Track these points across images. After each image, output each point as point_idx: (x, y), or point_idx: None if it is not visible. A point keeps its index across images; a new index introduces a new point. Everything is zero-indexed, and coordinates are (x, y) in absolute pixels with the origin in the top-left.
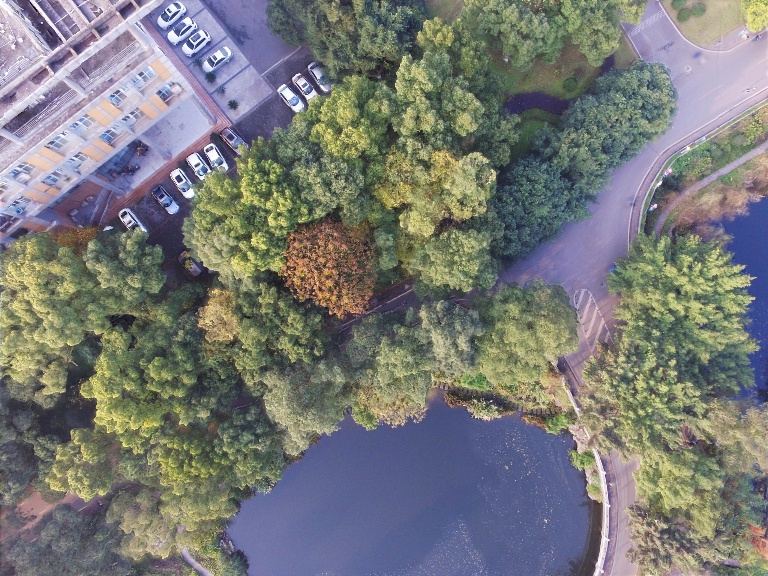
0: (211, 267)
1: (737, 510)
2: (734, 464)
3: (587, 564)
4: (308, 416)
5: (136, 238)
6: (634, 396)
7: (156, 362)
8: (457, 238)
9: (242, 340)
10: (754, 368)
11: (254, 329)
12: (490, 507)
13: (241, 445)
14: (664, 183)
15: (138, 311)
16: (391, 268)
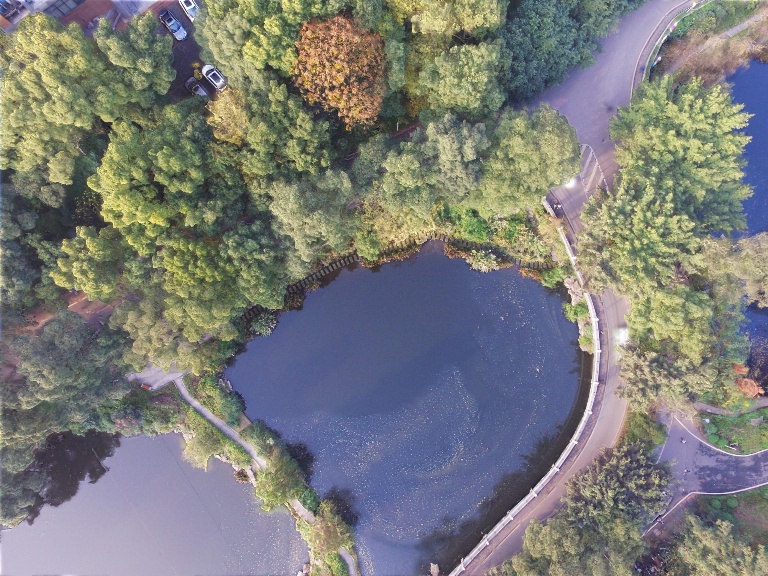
0: (222, 60)
1: (722, 351)
2: (723, 295)
3: (576, 412)
4: (314, 216)
5: (148, 21)
6: (631, 229)
7: (165, 149)
8: (467, 52)
9: (250, 141)
10: (746, 213)
11: (263, 123)
12: (485, 355)
13: (246, 251)
14: (669, 41)
15: (145, 119)
16: (398, 101)
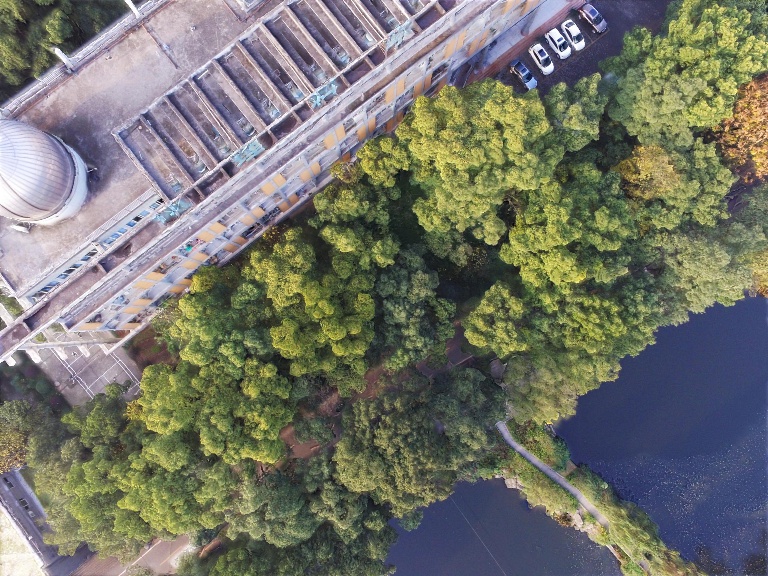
0: (656, 119)
1: None
2: None
3: None
4: (739, 271)
5: None
6: None
7: None
8: None
9: (667, 197)
10: None
11: (697, 181)
12: None
13: None
14: None
15: None
16: None
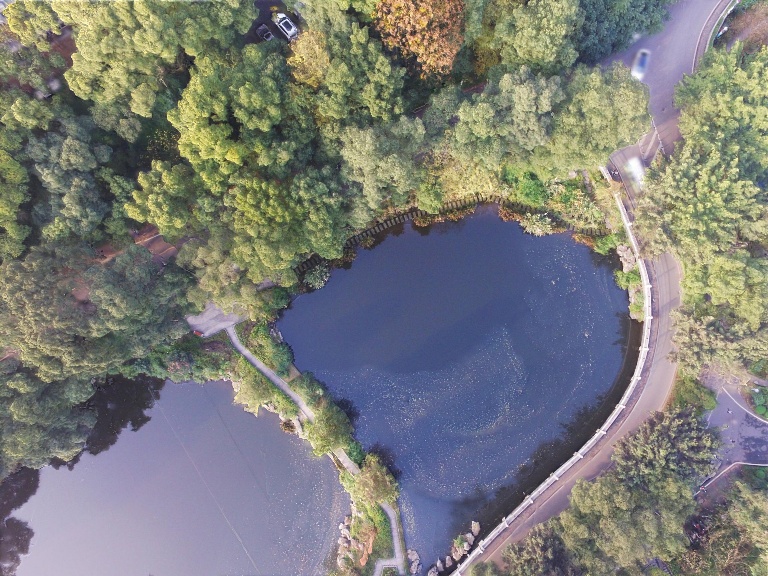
0: None
1: None
2: None
3: (622, 379)
4: (389, 159)
5: None
6: (694, 192)
7: (248, 84)
8: (545, 5)
9: (328, 83)
10: None
11: (345, 64)
12: (534, 318)
13: (316, 194)
14: (734, 13)
15: (222, 59)
16: (467, 57)
